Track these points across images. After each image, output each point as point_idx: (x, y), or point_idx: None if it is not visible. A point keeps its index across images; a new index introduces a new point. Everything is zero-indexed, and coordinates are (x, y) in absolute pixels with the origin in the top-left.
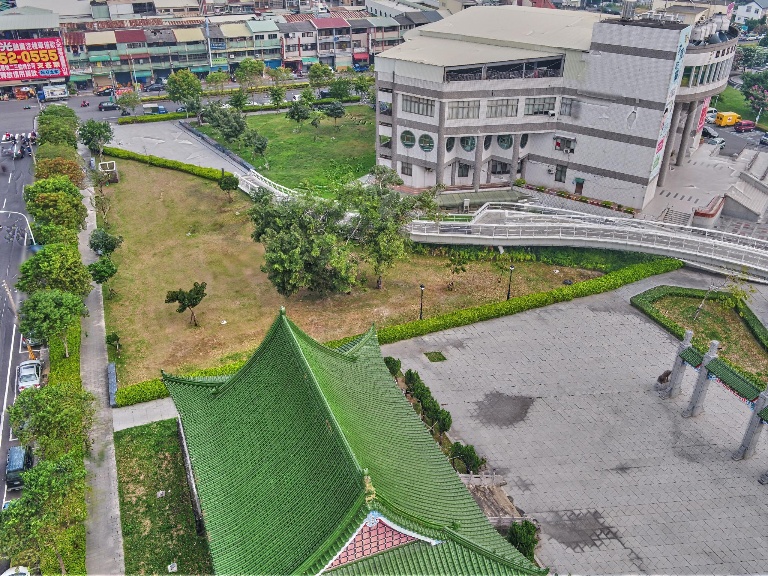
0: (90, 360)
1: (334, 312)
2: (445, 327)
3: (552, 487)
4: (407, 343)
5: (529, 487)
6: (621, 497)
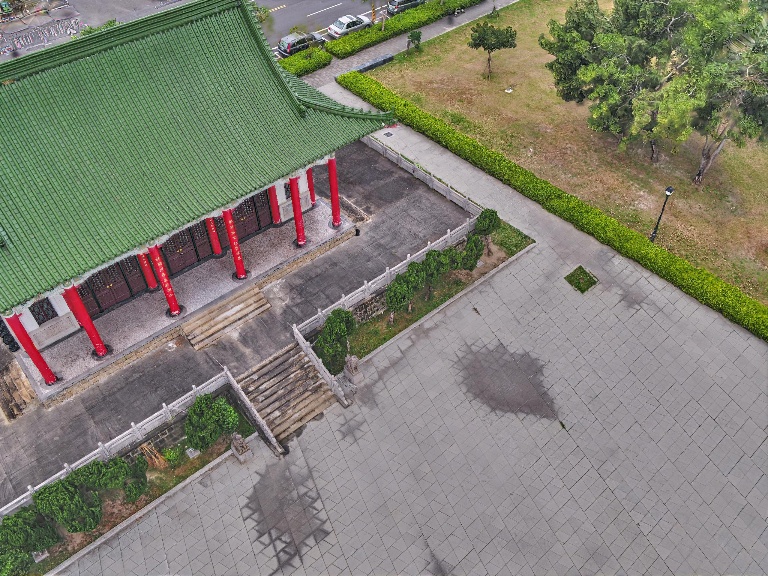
0: (392, 45)
1: (600, 159)
2: (658, 271)
3: (358, 466)
4: (590, 244)
5: (348, 436)
6: (370, 570)
